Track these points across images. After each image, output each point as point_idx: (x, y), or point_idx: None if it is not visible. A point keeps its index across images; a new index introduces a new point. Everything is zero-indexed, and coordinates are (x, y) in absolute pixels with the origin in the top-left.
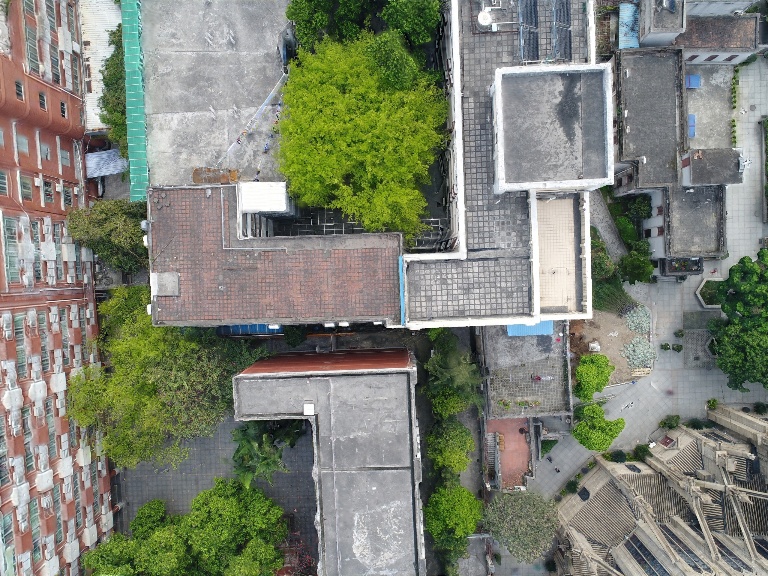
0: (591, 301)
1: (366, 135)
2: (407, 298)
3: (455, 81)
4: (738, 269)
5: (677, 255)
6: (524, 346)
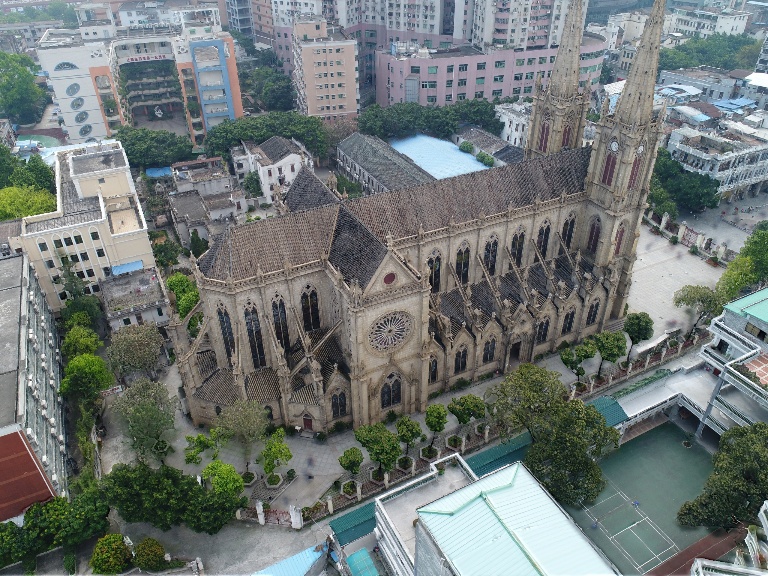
0: None
1: (6, 198)
2: (24, 230)
3: (57, 177)
4: None
5: (214, 234)
6: (131, 286)
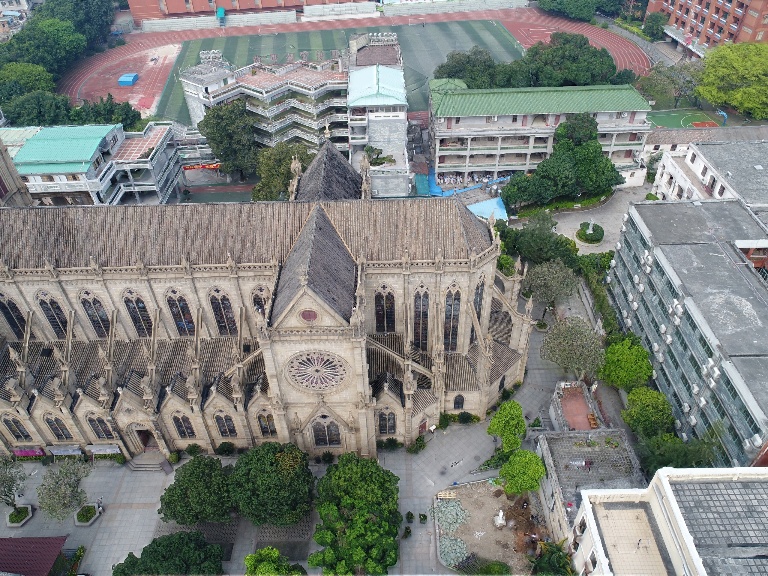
0: (587, 508)
1: None
2: None
3: None
4: (382, 573)
5: None
6: None
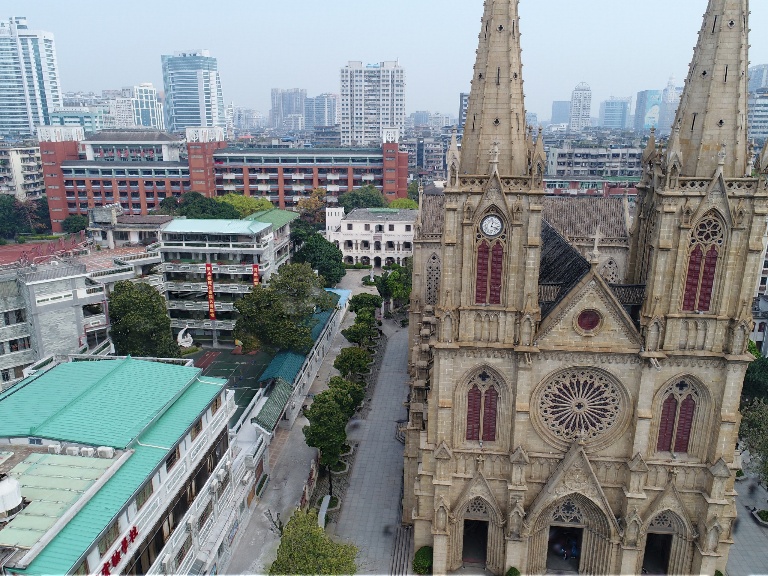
0: None
1: None
2: None
3: None
4: None
5: None
6: None
